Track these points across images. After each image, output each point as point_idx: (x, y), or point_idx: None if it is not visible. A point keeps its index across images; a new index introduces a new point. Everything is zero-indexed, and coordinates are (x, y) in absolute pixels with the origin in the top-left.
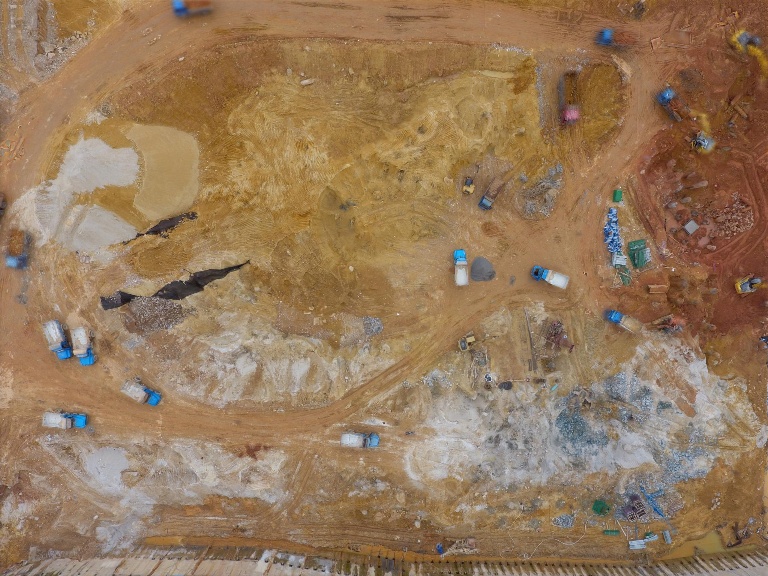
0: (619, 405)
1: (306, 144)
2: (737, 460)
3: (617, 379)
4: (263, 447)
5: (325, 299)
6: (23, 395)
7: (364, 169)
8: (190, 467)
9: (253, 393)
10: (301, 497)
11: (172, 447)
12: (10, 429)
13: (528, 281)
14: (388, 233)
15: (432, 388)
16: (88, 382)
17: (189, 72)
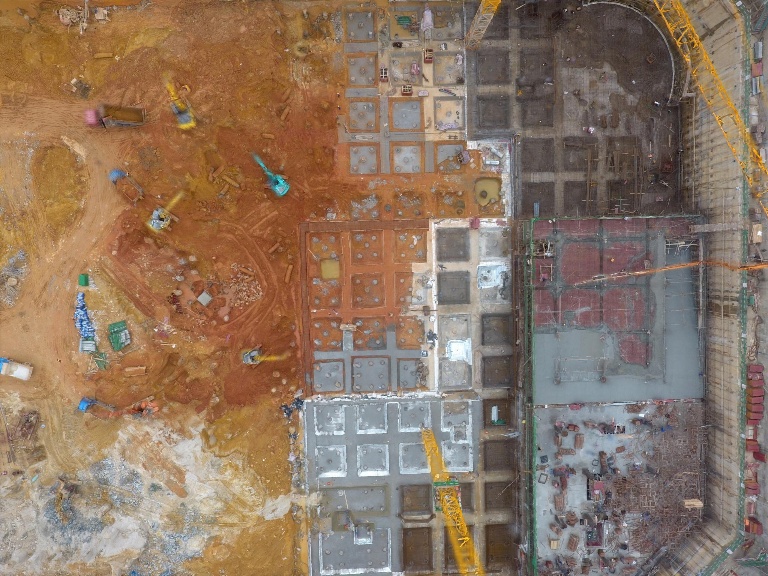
0: (110, 490)
1: None
2: (237, 537)
3: (101, 465)
4: None
5: None
6: None
7: None
8: None
9: None
10: None
11: None
12: None
13: None
14: None
15: None
16: None
17: None
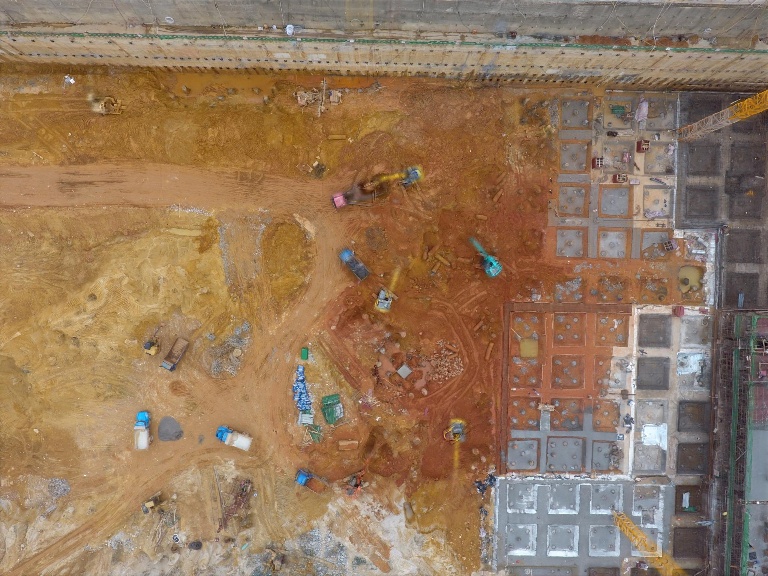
0: (314, 561)
1: None
2: None
3: (309, 536)
4: None
5: (12, 461)
6: None
7: (43, 333)
8: None
9: None
10: None
11: None
12: None
13: (217, 440)
14: (69, 396)
15: (115, 552)
16: None
17: None
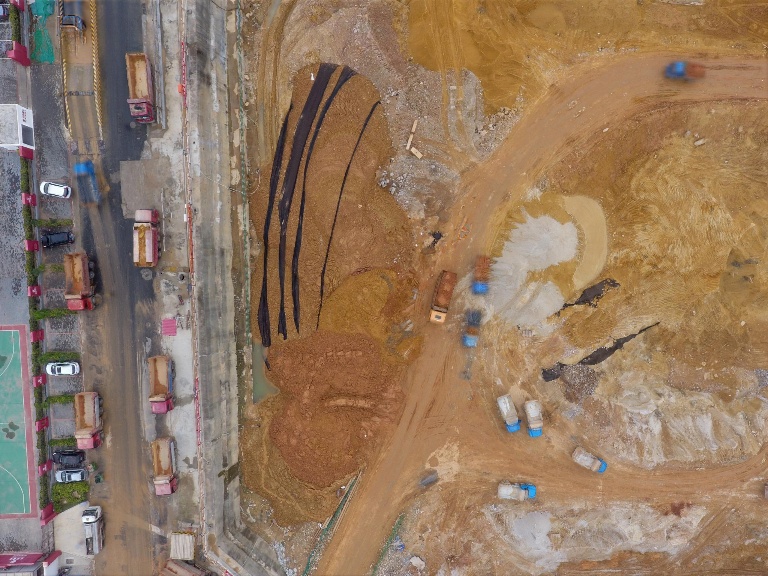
0: None
1: (712, 206)
2: None
3: None
4: (686, 504)
5: (716, 354)
6: (469, 468)
7: (759, 226)
8: (618, 527)
9: (673, 452)
10: (703, 548)
11: (611, 511)
12: (457, 501)
13: None
14: None
15: None
16: (531, 452)
17: (611, 142)
